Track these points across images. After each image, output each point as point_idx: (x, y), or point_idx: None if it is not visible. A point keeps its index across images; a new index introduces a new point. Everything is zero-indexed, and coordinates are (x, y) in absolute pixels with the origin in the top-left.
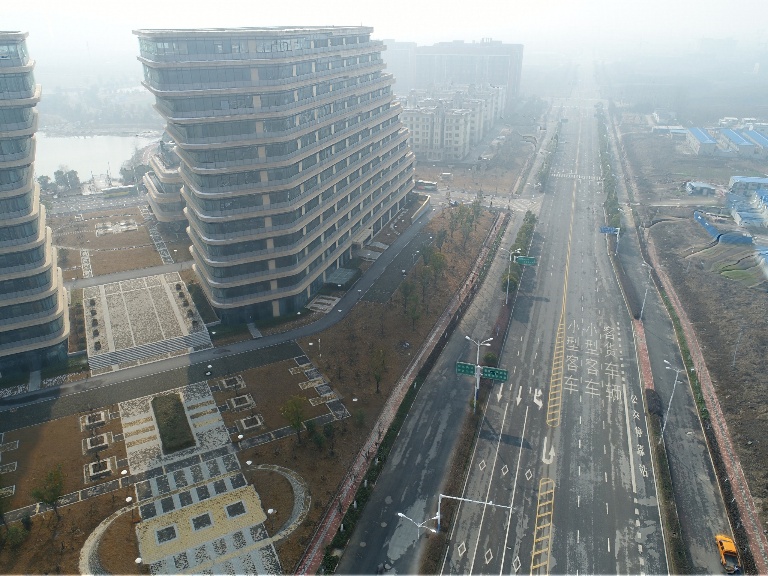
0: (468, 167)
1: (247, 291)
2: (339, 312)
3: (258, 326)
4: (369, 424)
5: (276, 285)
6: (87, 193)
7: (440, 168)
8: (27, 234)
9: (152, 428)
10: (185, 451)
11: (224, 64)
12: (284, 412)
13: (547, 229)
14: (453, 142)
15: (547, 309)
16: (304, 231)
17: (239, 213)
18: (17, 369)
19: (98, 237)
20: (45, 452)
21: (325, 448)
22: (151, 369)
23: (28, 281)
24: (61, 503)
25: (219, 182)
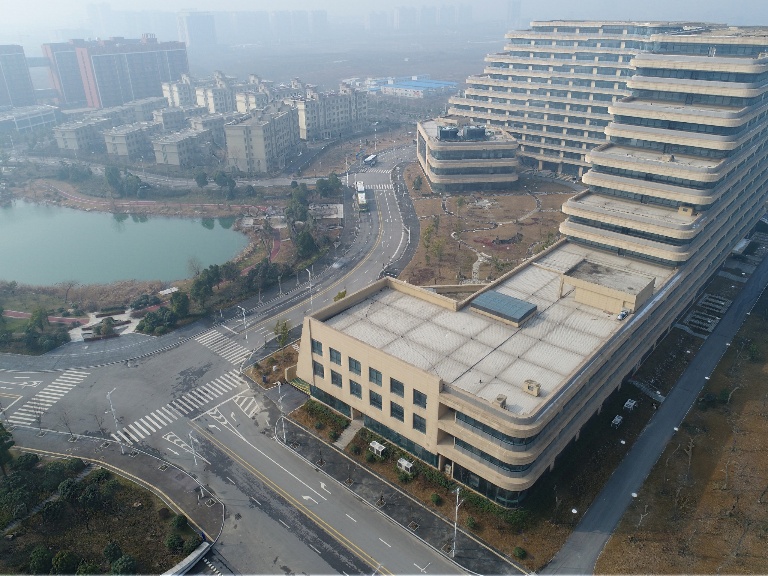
0: (392, 128)
1: None
2: None
3: None
4: None
5: None
6: (339, 216)
7: (383, 133)
8: None
9: None
10: None
11: None
12: None
13: None
14: (363, 114)
15: None
16: None
17: None
18: None
19: (510, 206)
20: None
21: None
22: None
23: None
24: None
25: None
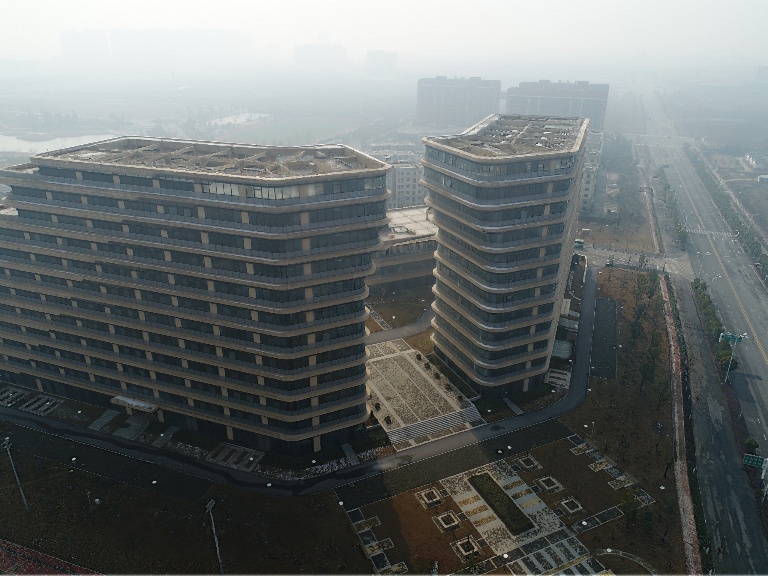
0: (601, 221)
1: (508, 370)
2: (589, 391)
3: (515, 402)
4: (676, 510)
5: (530, 364)
6: None
7: None
8: (362, 329)
9: (485, 508)
10: (529, 533)
11: (532, 181)
12: (623, 503)
13: (713, 295)
14: (582, 196)
15: (765, 388)
16: None
17: (516, 304)
18: (331, 442)
19: None
20: (409, 529)
21: (653, 534)
22: (446, 445)
23: (356, 368)
24: None
25: (506, 279)
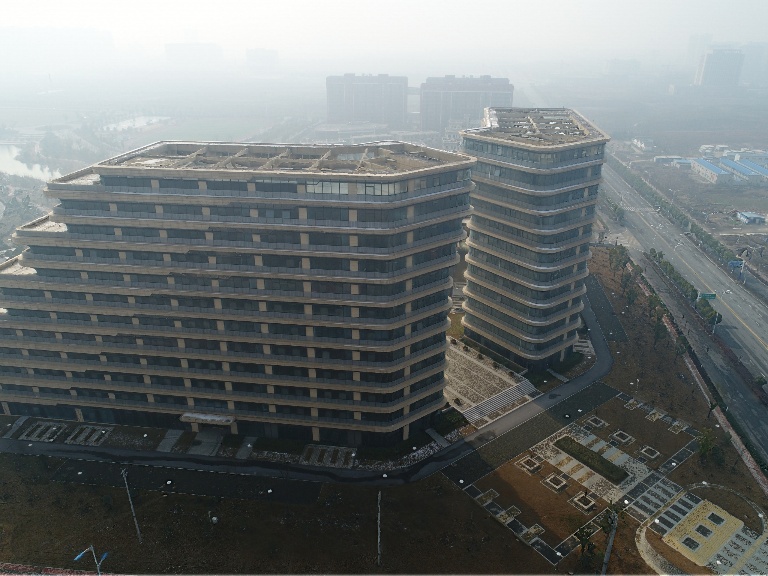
0: None
1: (550, 343)
2: None
3: (558, 371)
4: (730, 443)
5: (566, 336)
6: None
7: None
8: None
9: (581, 466)
10: (628, 481)
11: (579, 167)
12: (703, 441)
13: None
14: None
15: (743, 335)
16: None
17: (560, 281)
18: (415, 429)
19: None
20: (527, 495)
21: (723, 465)
22: (518, 417)
23: (440, 354)
24: (589, 532)
25: (554, 258)
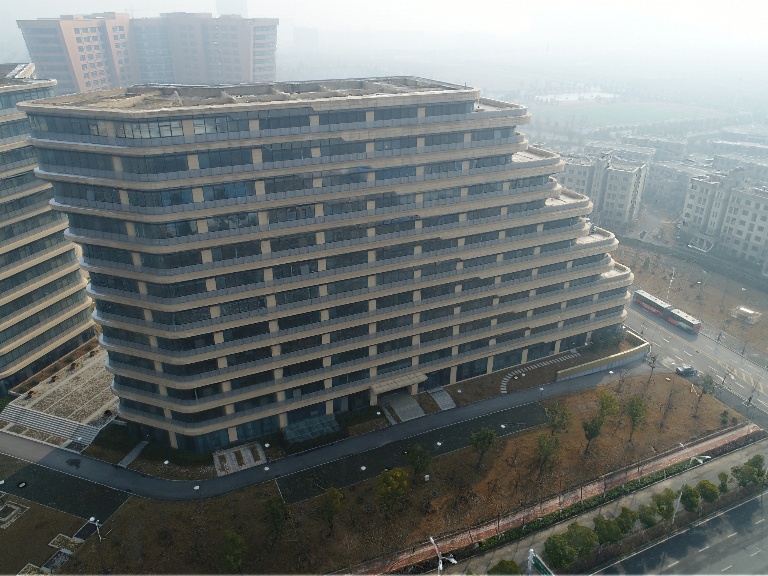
0: None
1: (141, 406)
2: (195, 489)
3: (142, 451)
4: None
5: (171, 414)
6: None
7: (761, 295)
8: None
9: None
10: None
11: (77, 148)
12: None
13: None
14: None
15: None
16: (220, 363)
17: (120, 320)
18: None
19: None
20: None
21: None
22: (14, 447)
23: None
24: None
25: (99, 280)
